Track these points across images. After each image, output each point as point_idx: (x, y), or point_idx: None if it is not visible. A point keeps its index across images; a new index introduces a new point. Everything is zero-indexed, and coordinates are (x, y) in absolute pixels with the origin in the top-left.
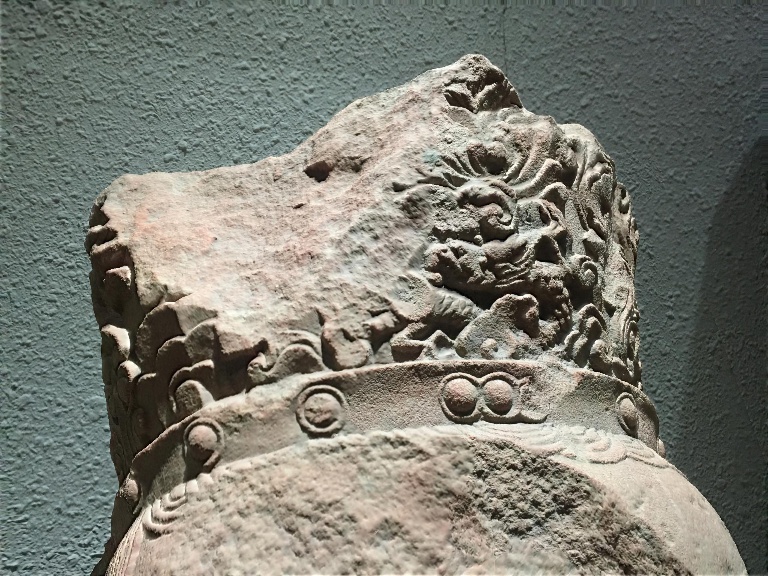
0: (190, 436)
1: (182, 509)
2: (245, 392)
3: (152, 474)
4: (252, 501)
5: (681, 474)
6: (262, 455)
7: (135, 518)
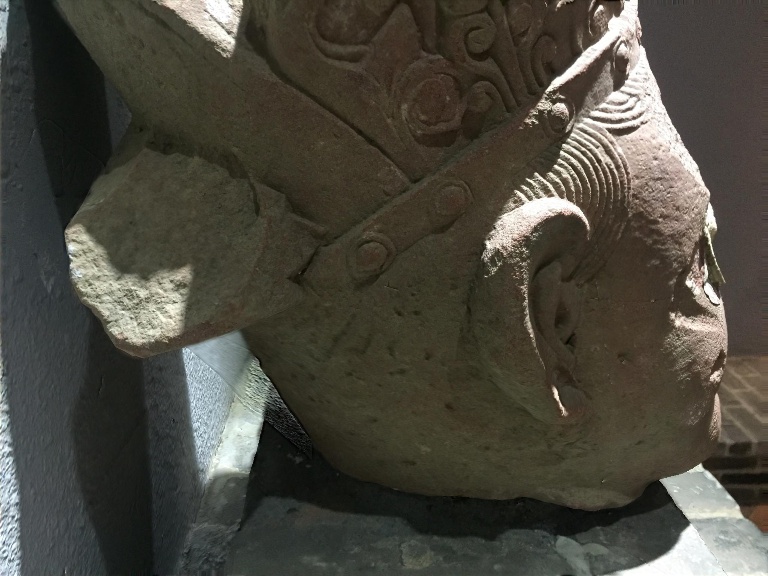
0: (624, 52)
1: (642, 105)
2: (617, 16)
3: (584, 92)
4: (656, 91)
5: None
6: (639, 62)
7: (568, 135)
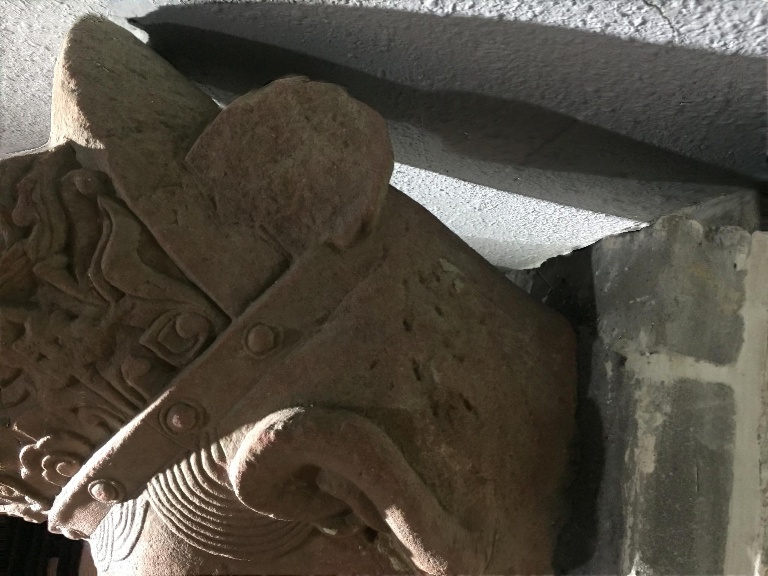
0: None
1: None
2: None
3: None
4: None
5: (103, 571)
6: None
7: None
